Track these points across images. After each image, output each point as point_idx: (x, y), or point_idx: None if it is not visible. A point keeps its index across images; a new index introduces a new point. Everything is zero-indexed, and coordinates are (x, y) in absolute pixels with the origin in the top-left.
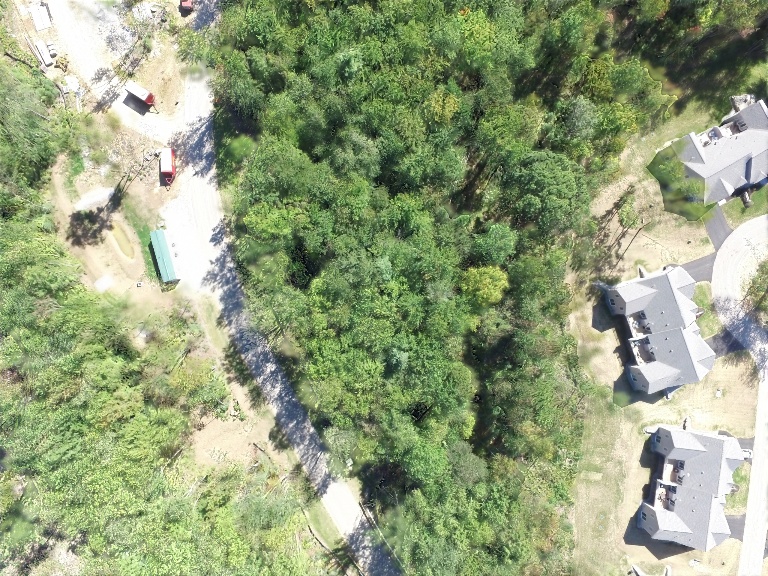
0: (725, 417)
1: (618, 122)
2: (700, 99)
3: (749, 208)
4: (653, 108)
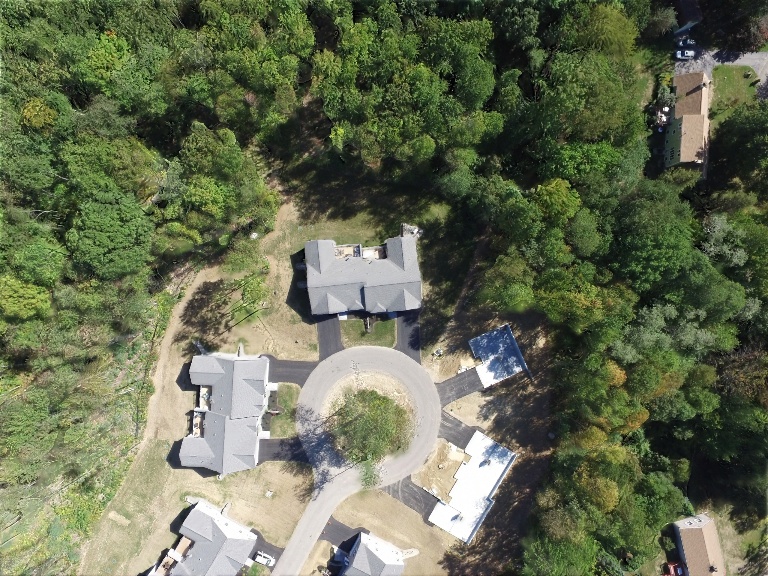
0: (265, 518)
1: (192, 197)
2: (373, 213)
3: (370, 334)
4: (241, 198)
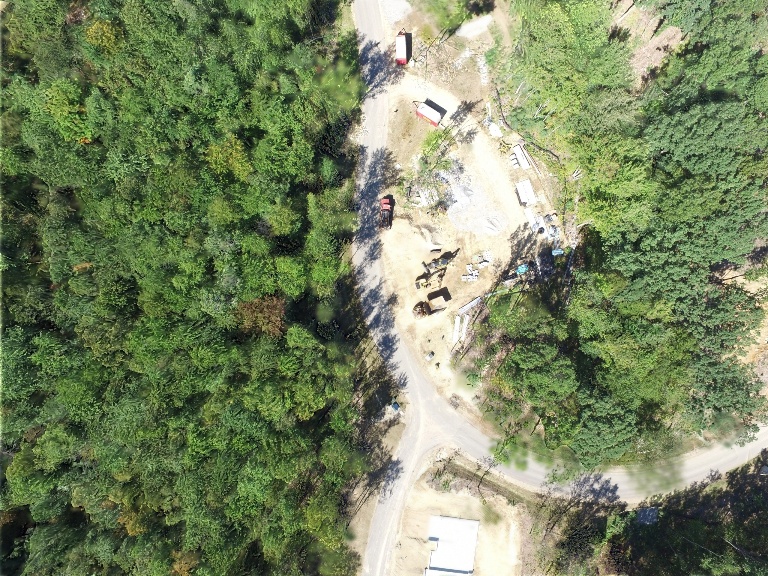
0: None
1: None
2: None
3: None
4: None
